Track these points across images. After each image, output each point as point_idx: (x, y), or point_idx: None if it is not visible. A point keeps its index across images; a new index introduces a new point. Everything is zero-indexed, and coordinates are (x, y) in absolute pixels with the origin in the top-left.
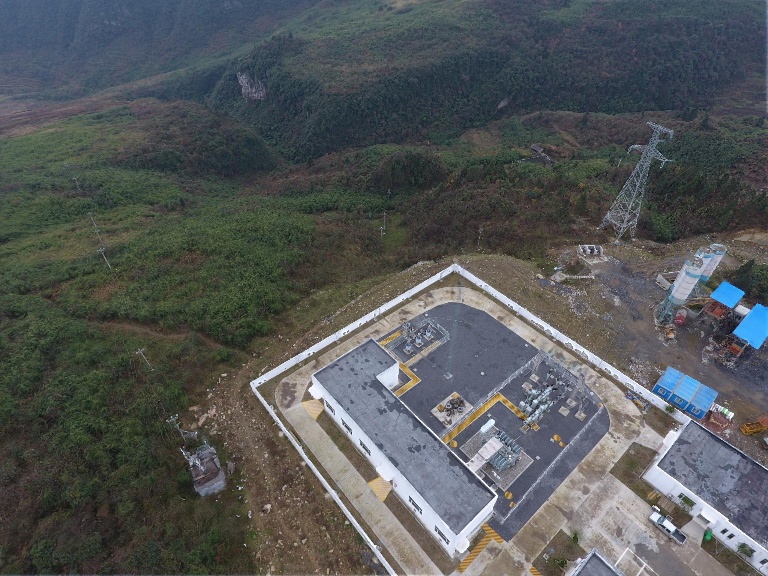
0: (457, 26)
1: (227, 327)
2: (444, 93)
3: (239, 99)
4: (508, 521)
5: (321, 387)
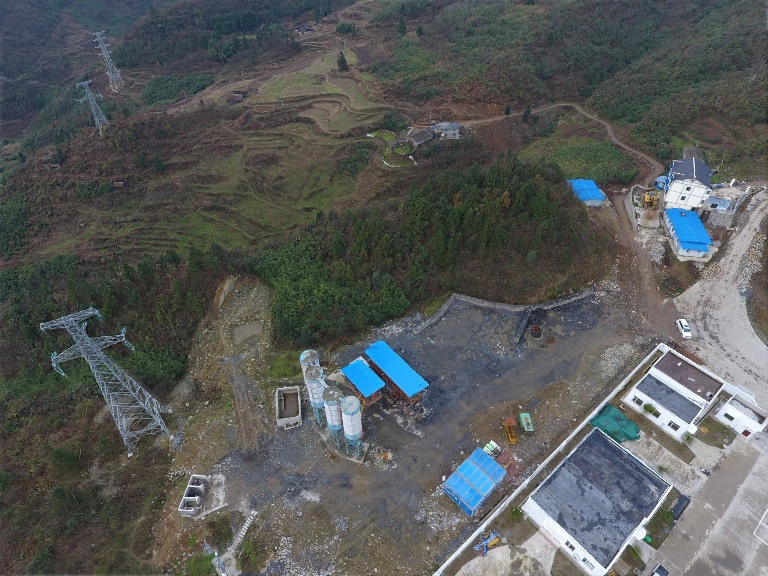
0: None
1: None
2: None
3: None
4: None
5: None
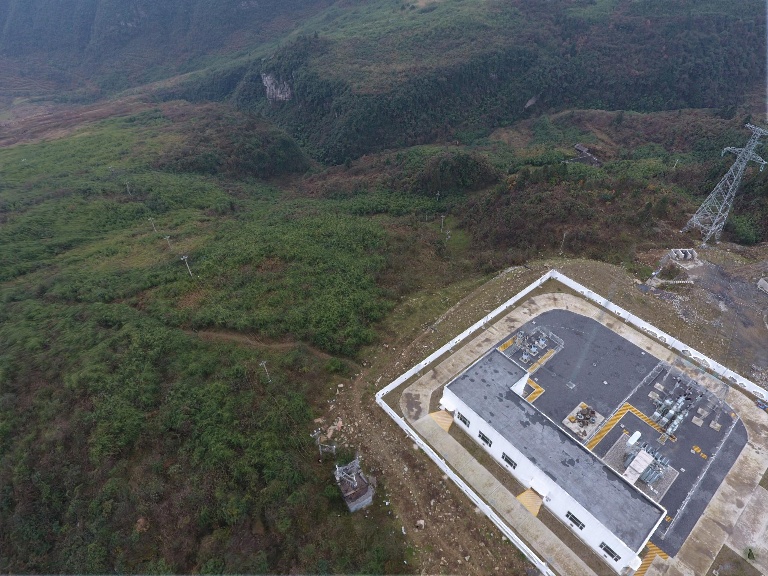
0: (484, 25)
1: (335, 336)
2: (472, 92)
3: (261, 100)
4: (668, 536)
5: (457, 399)
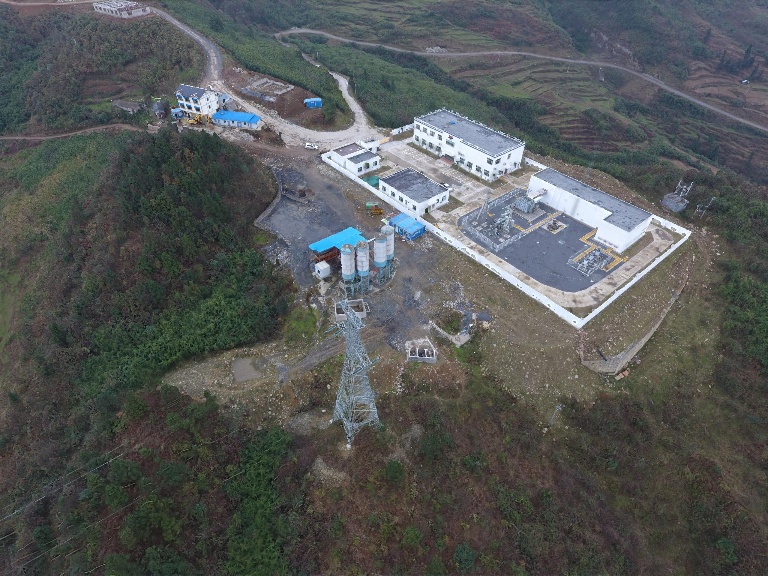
0: None
1: None
2: None
3: None
4: None
5: None
